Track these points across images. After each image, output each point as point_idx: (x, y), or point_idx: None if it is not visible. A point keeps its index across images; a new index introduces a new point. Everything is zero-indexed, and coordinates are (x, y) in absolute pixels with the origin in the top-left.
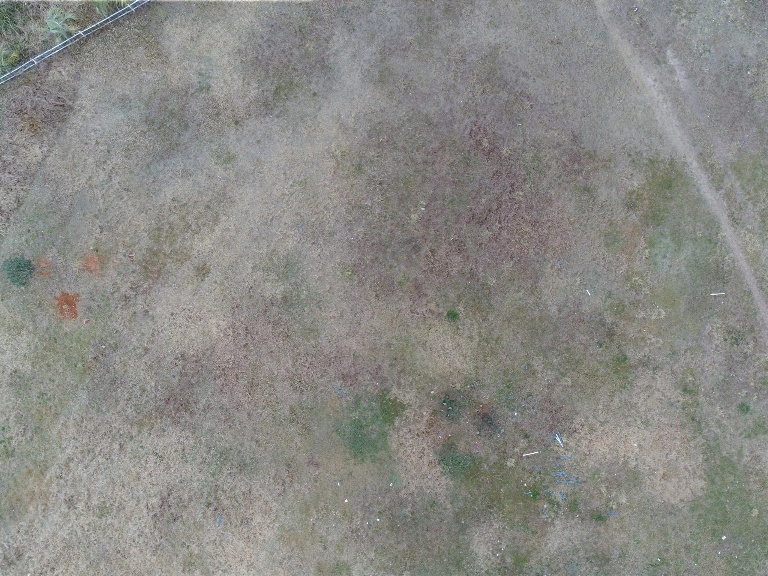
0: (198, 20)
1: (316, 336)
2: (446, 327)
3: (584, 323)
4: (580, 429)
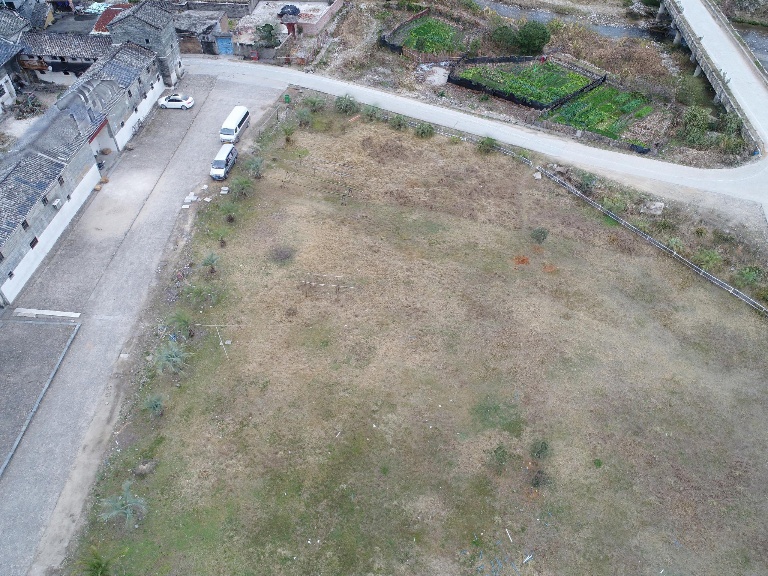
0: (714, 303)
1: (549, 378)
2: (587, 459)
3: (635, 570)
4: (543, 575)
